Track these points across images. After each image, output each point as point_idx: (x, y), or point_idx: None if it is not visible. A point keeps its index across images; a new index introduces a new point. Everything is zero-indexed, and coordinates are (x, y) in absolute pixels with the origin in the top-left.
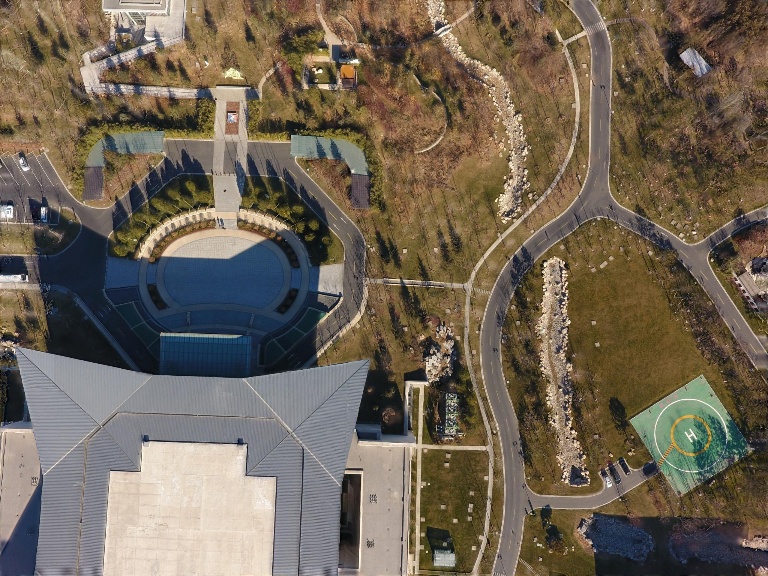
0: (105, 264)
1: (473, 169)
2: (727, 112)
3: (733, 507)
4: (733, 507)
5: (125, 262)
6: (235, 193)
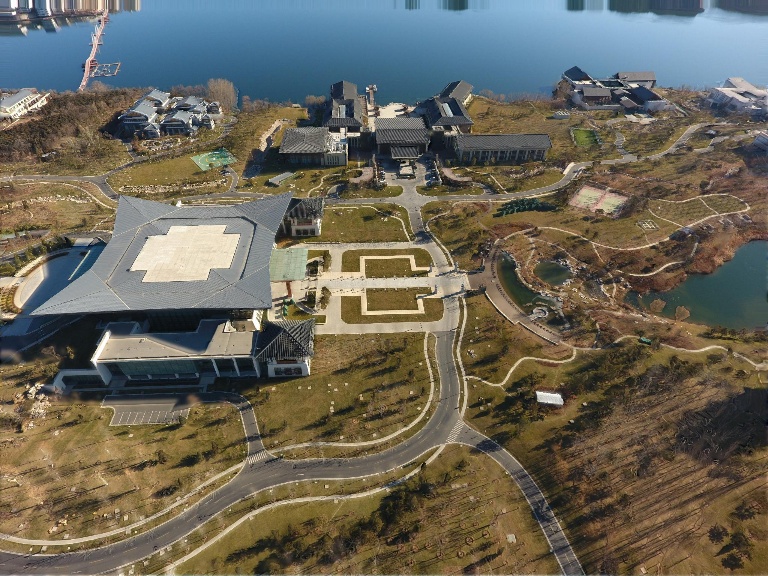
0: (5, 337)
1: (55, 206)
2: (76, 144)
3: (240, 146)
4: (240, 146)
5: (12, 327)
6: (1, 280)
